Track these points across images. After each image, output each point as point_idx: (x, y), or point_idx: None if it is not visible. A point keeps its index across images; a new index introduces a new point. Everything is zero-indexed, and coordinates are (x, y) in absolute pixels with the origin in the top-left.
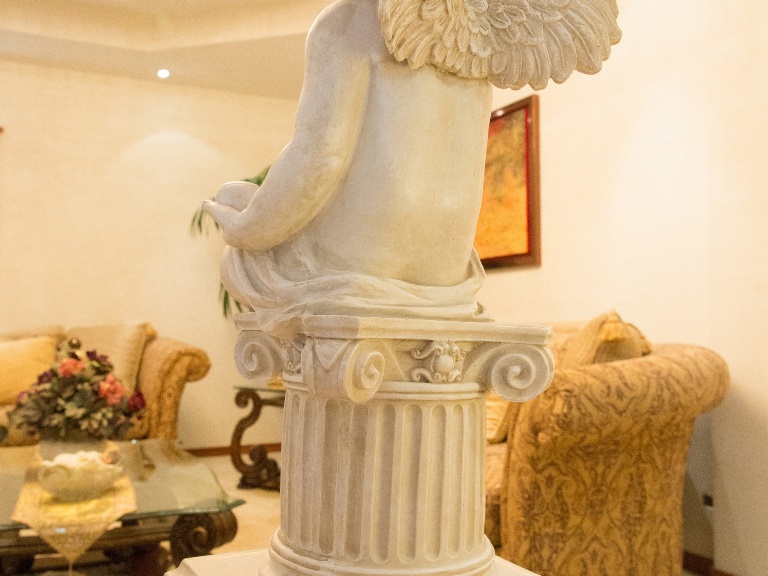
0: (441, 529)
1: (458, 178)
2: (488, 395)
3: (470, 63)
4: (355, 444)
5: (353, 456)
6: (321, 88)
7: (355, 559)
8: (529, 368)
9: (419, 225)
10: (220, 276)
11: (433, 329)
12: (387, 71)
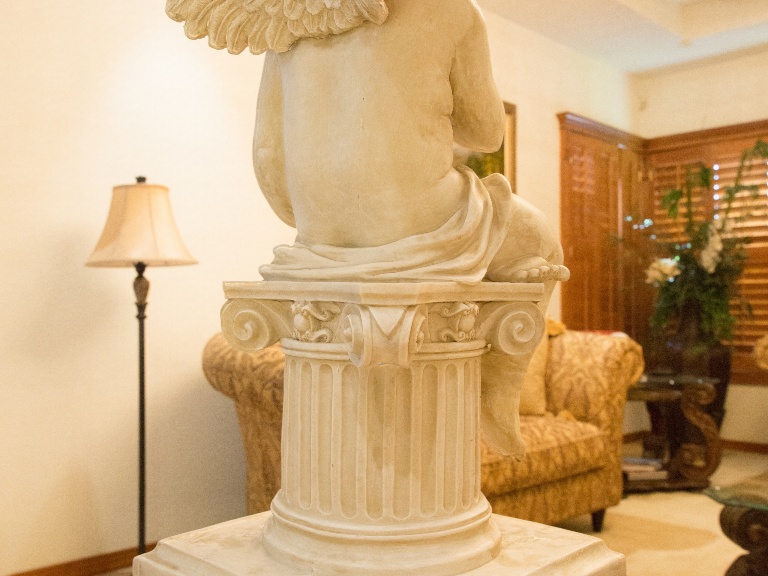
0: (311, 481)
1: (344, 137)
2: None
3: None
4: None
5: None
6: None
7: None
8: (351, 330)
9: (317, 192)
10: None
11: (290, 290)
12: (281, 61)
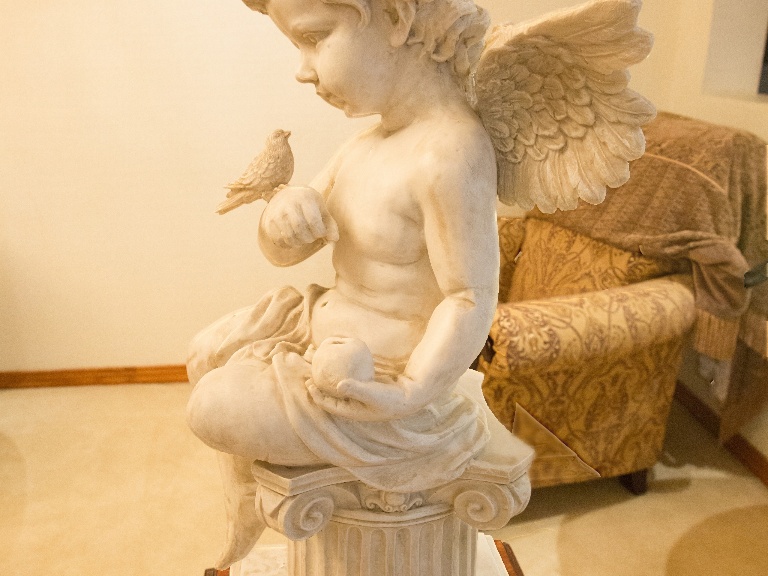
0: None
1: None
2: None
3: None
4: (459, 540)
5: None
6: (492, 247)
7: None
8: None
9: None
10: (254, 445)
11: None
12: None
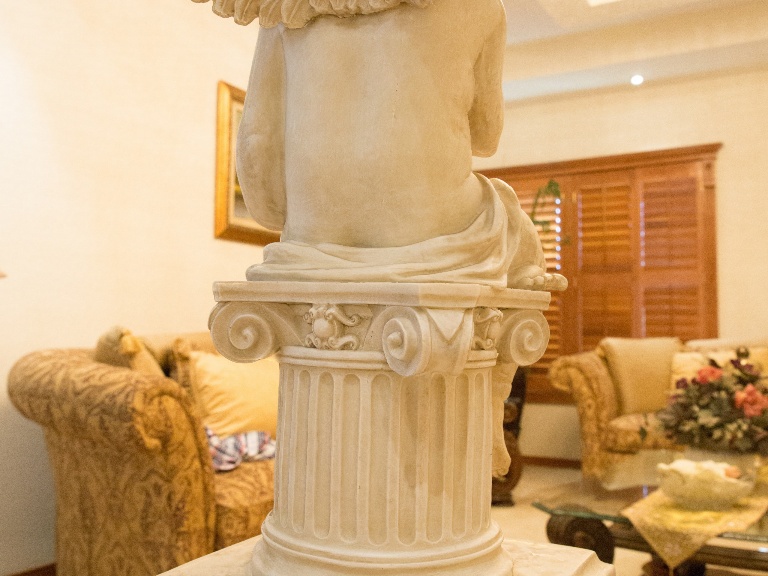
0: (330, 507)
1: (371, 125)
2: None
3: None
4: None
5: None
6: None
7: (276, 518)
8: (403, 335)
9: (333, 185)
10: None
11: (308, 291)
12: (289, 38)
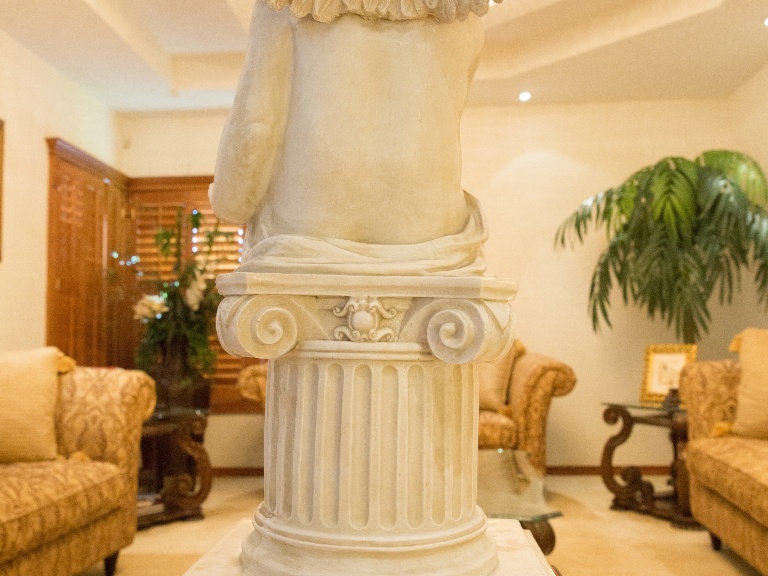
0: (369, 497)
1: (397, 127)
2: (435, 357)
3: (399, 3)
4: (291, 404)
5: (289, 416)
6: (247, 60)
7: (288, 518)
8: (462, 325)
9: (353, 181)
10: None
11: (346, 284)
12: (305, 30)
